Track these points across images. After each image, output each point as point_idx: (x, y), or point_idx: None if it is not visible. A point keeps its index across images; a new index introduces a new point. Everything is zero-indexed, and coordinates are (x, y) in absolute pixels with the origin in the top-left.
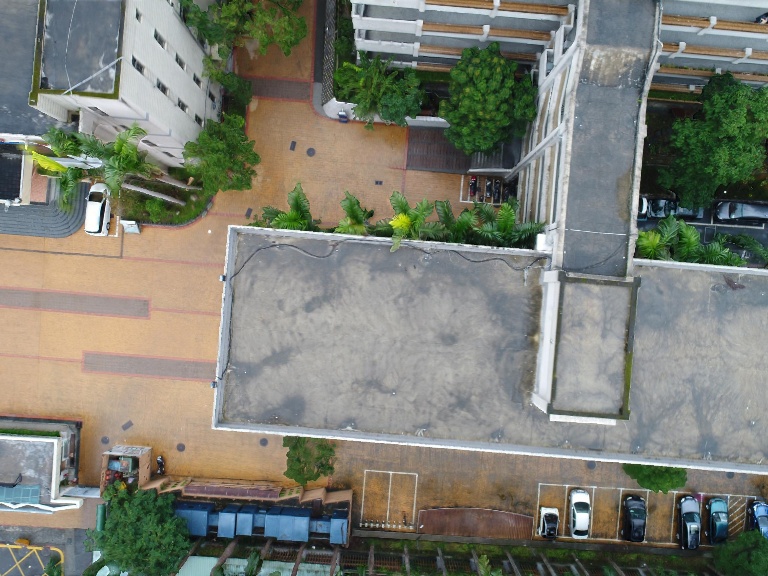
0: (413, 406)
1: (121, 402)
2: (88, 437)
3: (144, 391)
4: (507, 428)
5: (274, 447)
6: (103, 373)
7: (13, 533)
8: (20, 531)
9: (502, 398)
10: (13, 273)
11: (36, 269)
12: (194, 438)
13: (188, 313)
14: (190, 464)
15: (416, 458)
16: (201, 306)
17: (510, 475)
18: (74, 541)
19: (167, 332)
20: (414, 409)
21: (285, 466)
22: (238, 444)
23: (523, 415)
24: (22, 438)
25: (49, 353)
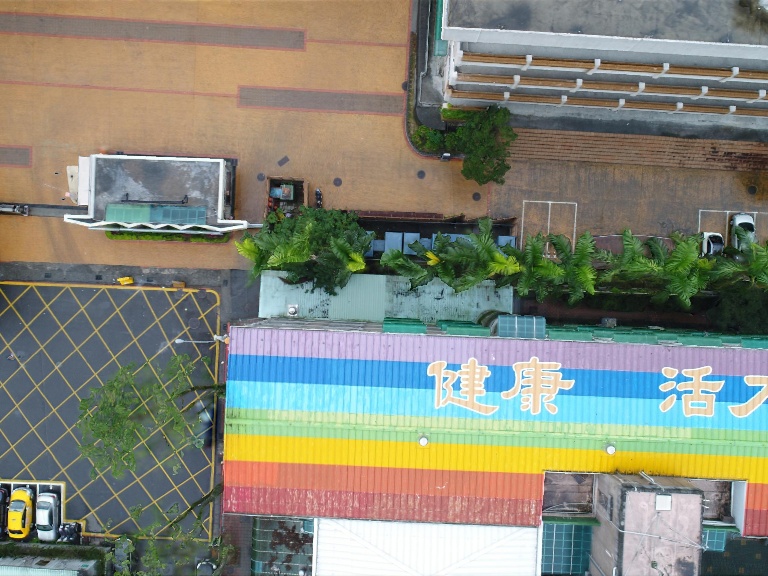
0: (640, 12)
1: (277, 137)
2: (244, 175)
3: (300, 125)
4: (735, 33)
5: (432, 179)
6: (258, 108)
7: (168, 276)
8: (176, 274)
9: (730, 2)
10: (167, 7)
11: (191, 2)
12: (351, 172)
13: (344, 44)
14: (347, 199)
15: (575, 187)
16: (357, 36)
17: (670, 202)
18: (230, 283)
19: (323, 64)
20: (641, 15)
21: (443, 198)
22: (395, 177)
23: (751, 19)
24: (188, 158)
25: (204, 88)
